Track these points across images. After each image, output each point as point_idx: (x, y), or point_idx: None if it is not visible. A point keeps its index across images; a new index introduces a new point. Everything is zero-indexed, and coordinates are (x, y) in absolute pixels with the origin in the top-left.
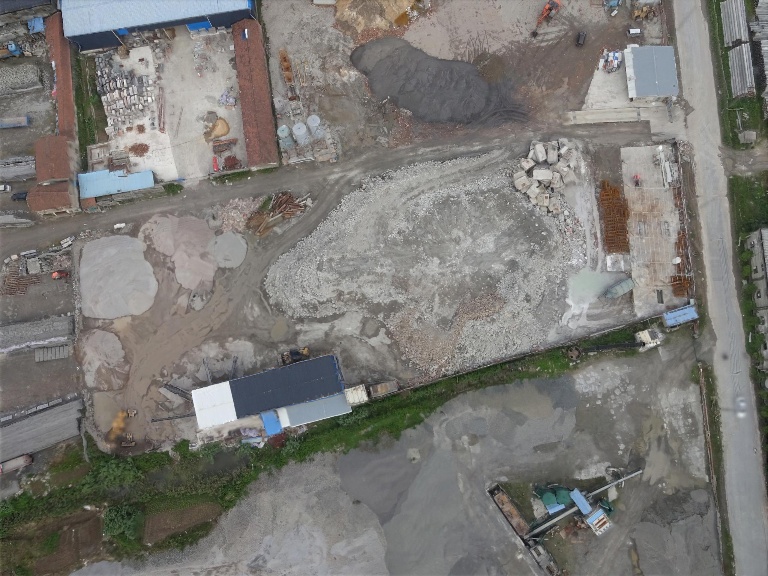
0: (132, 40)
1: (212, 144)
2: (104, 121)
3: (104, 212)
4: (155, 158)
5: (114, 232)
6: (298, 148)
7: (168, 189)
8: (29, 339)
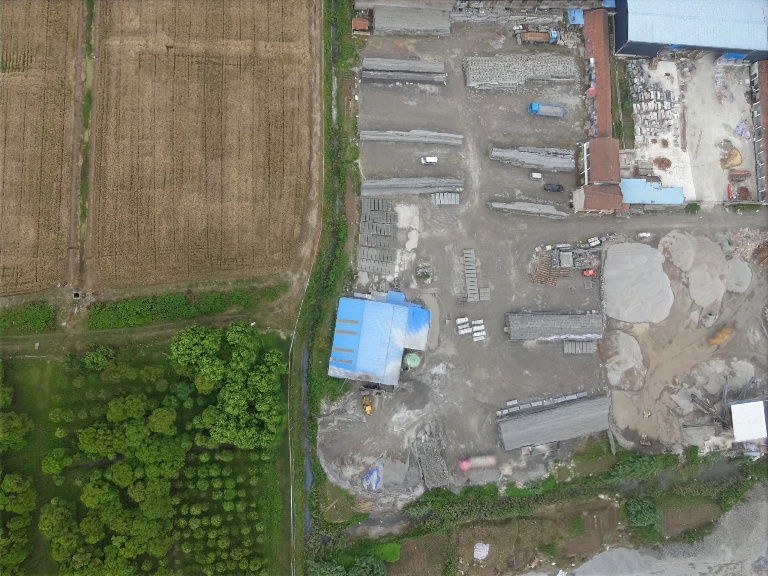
0: (665, 53)
1: (728, 172)
2: (632, 128)
3: (629, 218)
4: (676, 175)
5: (636, 239)
6: None
7: (689, 208)
8: (568, 331)
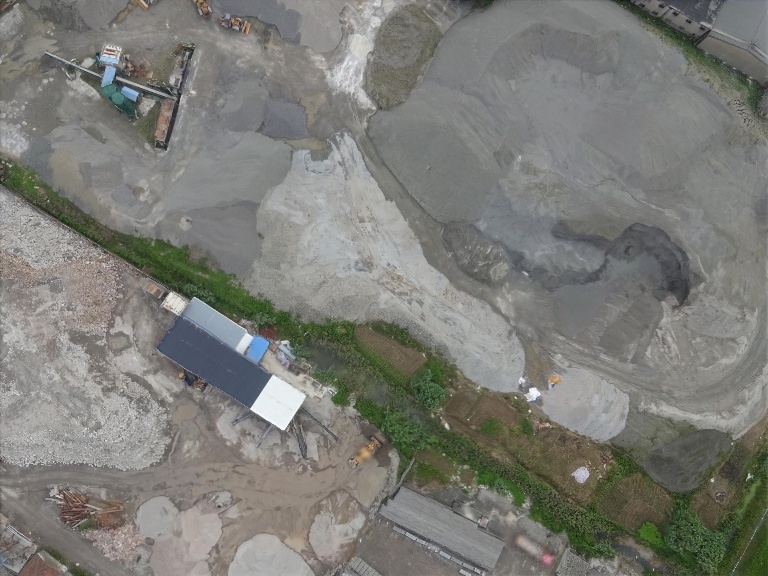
0: None
1: None
2: None
3: None
4: None
5: None
6: (6, 548)
7: None
8: None
